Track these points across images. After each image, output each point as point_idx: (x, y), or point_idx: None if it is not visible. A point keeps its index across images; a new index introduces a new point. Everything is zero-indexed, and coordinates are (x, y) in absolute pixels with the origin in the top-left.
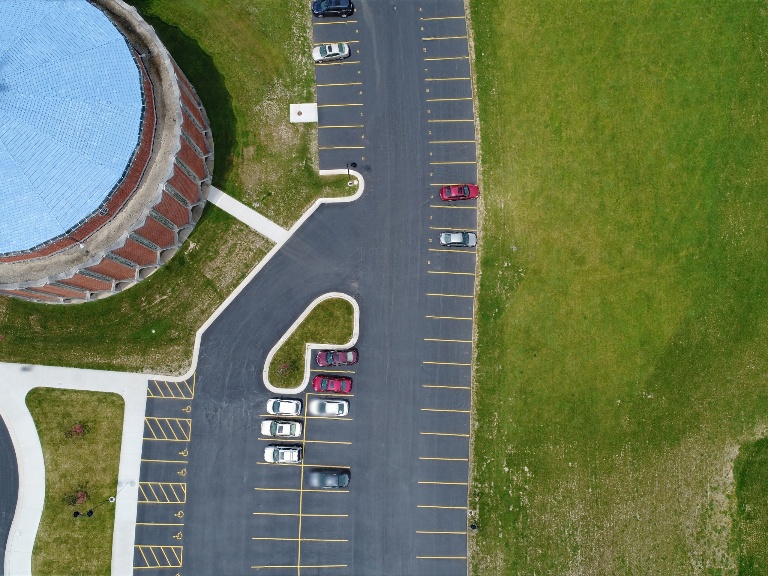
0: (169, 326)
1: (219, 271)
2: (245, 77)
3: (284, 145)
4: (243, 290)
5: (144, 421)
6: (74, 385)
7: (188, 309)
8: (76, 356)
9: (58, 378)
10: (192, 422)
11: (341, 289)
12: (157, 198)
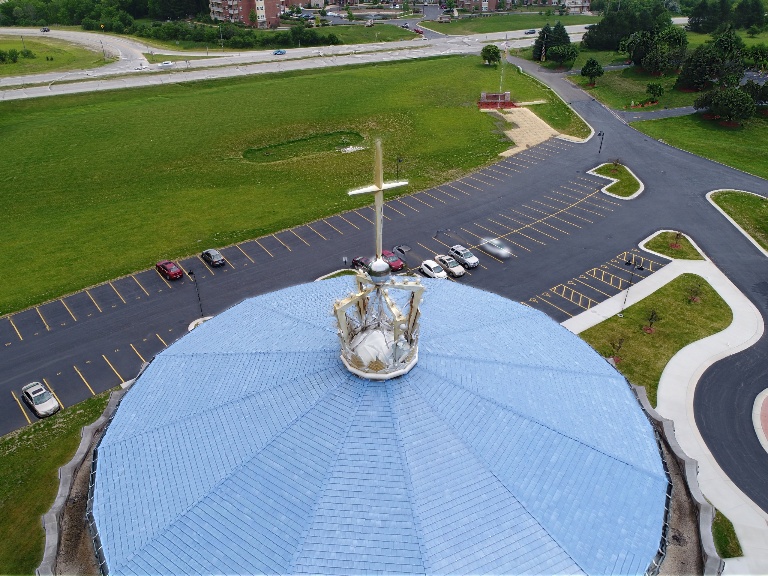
0: None
1: None
2: None
3: None
4: None
5: None
6: None
7: None
8: None
9: None
10: None
11: None
12: None
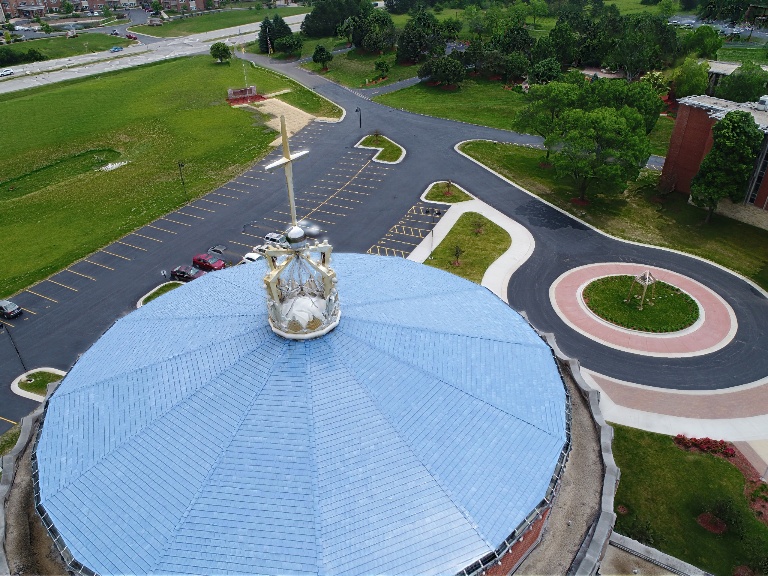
0: None
1: None
2: None
3: None
4: None
5: None
6: None
7: None
8: None
9: None
10: None
11: None
12: None
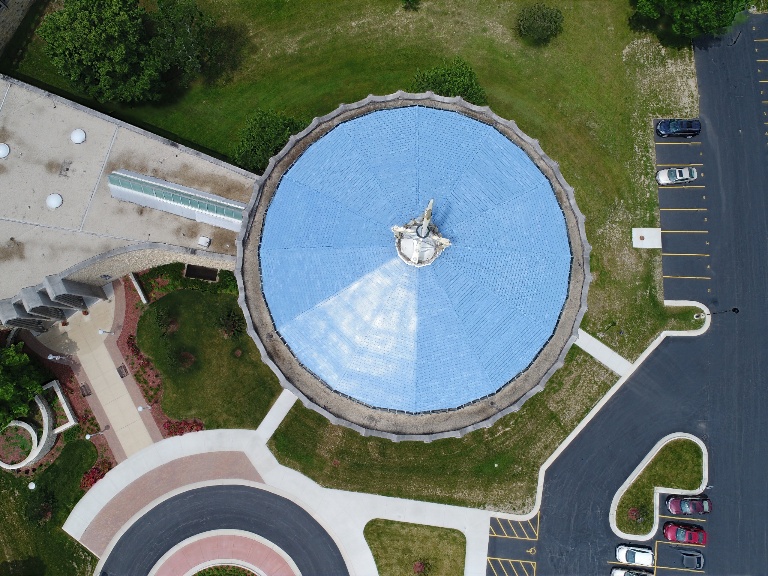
0: (512, 460)
1: (563, 404)
2: (587, 197)
3: (627, 271)
4: (587, 425)
5: (486, 561)
6: (414, 519)
7: (531, 443)
8: (416, 487)
9: (397, 510)
10: (536, 565)
11: (688, 429)
12: (567, 350)
